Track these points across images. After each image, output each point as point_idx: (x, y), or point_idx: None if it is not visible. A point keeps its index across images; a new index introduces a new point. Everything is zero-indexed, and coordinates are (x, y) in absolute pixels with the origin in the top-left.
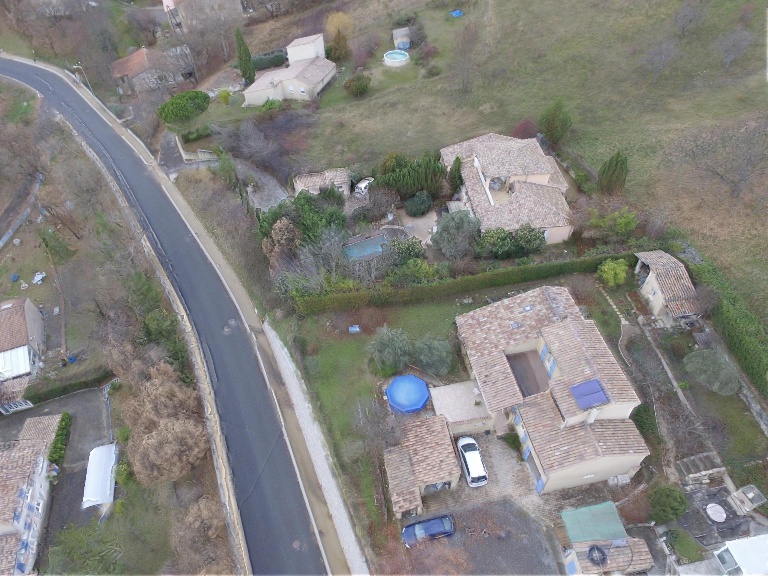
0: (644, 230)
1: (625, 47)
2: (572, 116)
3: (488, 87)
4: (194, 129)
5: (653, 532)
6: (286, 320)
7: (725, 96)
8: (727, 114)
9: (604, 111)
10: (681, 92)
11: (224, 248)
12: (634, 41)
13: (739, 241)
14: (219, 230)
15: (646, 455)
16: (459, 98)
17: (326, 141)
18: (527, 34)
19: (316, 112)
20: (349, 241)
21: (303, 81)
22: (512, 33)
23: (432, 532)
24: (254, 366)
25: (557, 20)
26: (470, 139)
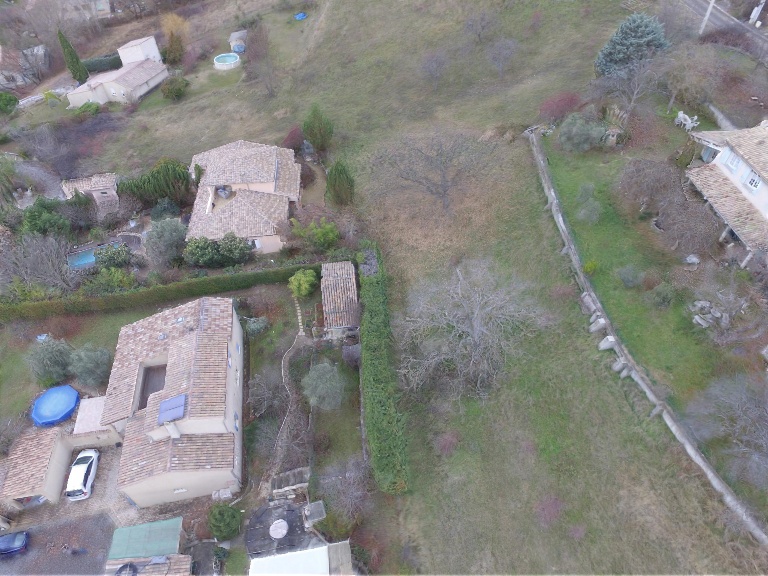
0: None
1: (427, 53)
2: (351, 123)
3: (293, 92)
4: (3, 131)
5: None
6: None
7: (485, 105)
8: (476, 123)
9: (381, 118)
10: (452, 100)
11: None
12: (437, 47)
13: (432, 252)
14: None
15: (226, 470)
16: (263, 103)
17: (123, 145)
18: (347, 39)
19: (130, 115)
20: (78, 248)
21: (122, 84)
22: (334, 37)
23: None
24: None
25: (379, 25)
26: None
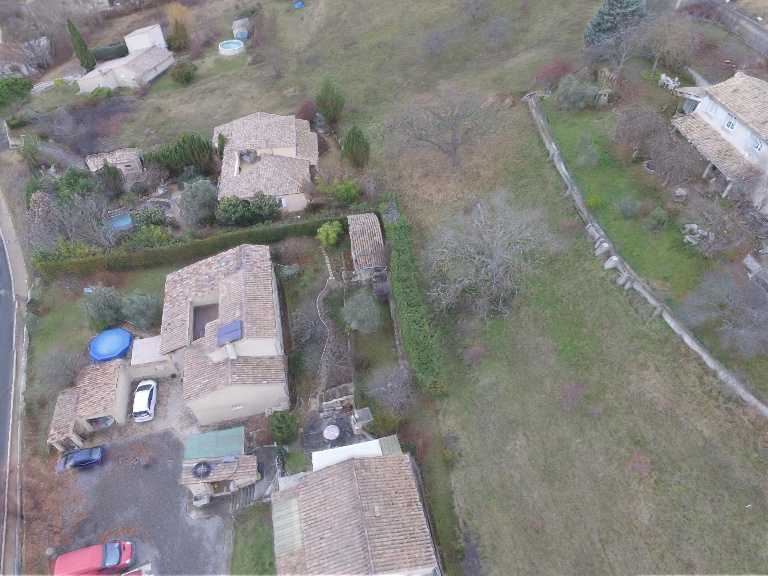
0: (367, 196)
1: (425, 34)
2: (358, 98)
3: (299, 73)
4: (18, 115)
5: None
6: (40, 287)
7: (484, 77)
8: (478, 92)
9: (386, 93)
10: (453, 74)
11: (18, 226)
12: (434, 29)
13: (446, 204)
14: (17, 209)
15: (280, 385)
16: (271, 83)
17: (139, 125)
18: (347, 23)
19: (142, 98)
20: (112, 213)
21: (131, 69)
22: (335, 23)
23: (78, 459)
24: (8, 331)
25: (377, 10)
26: (240, 118)
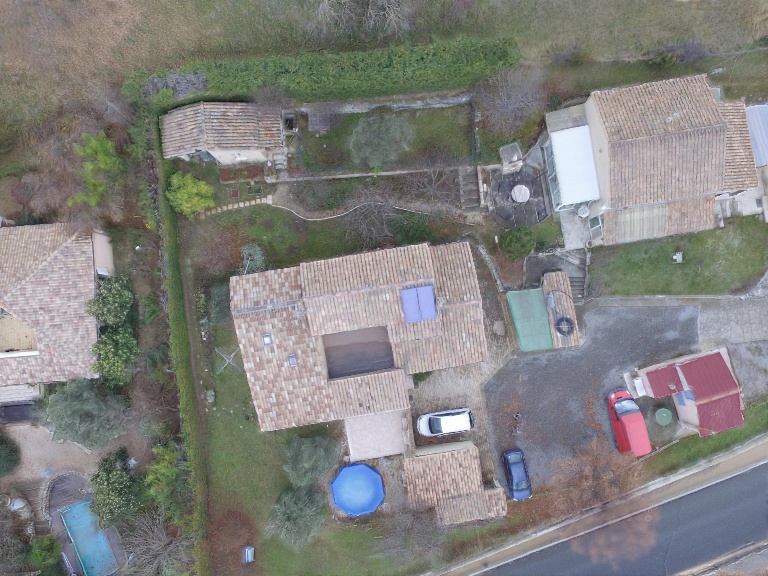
0: (113, 125)
1: None
2: None
3: None
4: None
5: (532, 259)
6: None
7: None
8: None
9: None
10: None
11: None
12: None
13: None
14: None
15: None
16: None
17: None
18: None
19: None
20: (77, 571)
21: None
22: None
23: (524, 475)
24: None
25: None
26: None
